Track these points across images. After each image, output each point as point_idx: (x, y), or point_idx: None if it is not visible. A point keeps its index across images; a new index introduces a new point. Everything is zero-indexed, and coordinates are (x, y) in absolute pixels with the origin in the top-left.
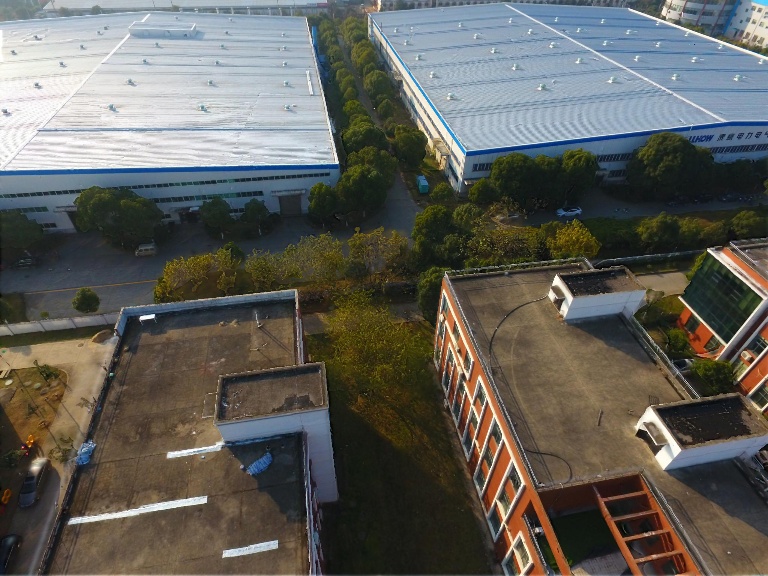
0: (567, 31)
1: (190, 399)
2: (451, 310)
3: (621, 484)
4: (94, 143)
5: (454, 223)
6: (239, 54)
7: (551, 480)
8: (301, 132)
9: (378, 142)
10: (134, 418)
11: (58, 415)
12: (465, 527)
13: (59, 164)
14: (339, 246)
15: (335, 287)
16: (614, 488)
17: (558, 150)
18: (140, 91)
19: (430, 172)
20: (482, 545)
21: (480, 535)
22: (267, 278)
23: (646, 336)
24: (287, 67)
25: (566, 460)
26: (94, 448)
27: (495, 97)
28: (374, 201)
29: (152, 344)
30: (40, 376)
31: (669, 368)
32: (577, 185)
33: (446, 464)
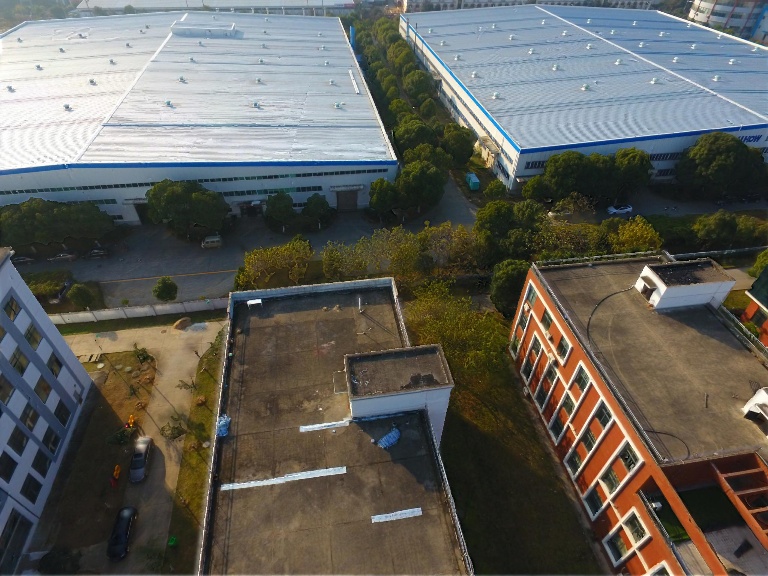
0: (600, 33)
1: (310, 378)
2: (541, 299)
3: (738, 462)
4: (158, 138)
5: (514, 218)
6: (281, 53)
7: (670, 457)
8: (354, 129)
9: (429, 140)
10: (261, 395)
11: (152, 397)
12: (560, 507)
13: (129, 158)
14: (414, 238)
15: (405, 279)
16: (732, 465)
17: (609, 149)
18: (192, 88)
19: (478, 170)
20: (579, 524)
21: (575, 515)
22: (346, 268)
23: (738, 325)
24: (329, 66)
25: (681, 439)
26: (230, 421)
27: (540, 97)
28: (433, 197)
29: (262, 327)
30: (130, 360)
31: (765, 355)
32: (630, 183)
33: (533, 448)
